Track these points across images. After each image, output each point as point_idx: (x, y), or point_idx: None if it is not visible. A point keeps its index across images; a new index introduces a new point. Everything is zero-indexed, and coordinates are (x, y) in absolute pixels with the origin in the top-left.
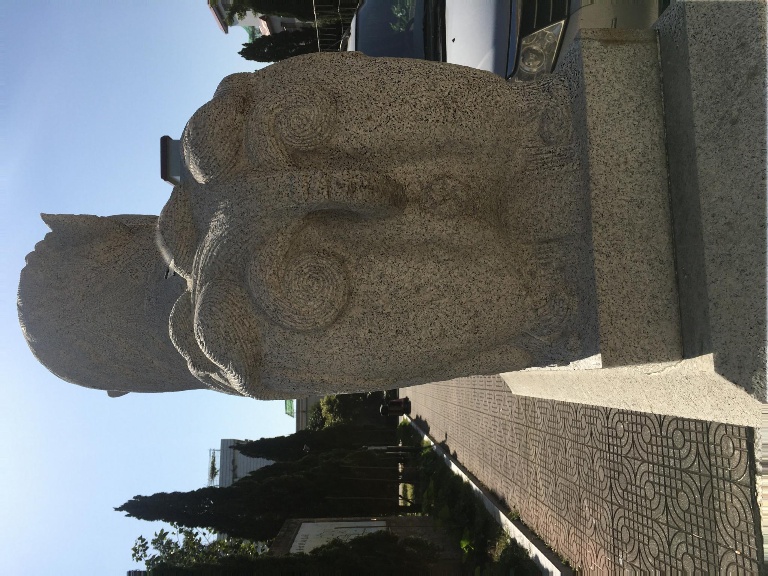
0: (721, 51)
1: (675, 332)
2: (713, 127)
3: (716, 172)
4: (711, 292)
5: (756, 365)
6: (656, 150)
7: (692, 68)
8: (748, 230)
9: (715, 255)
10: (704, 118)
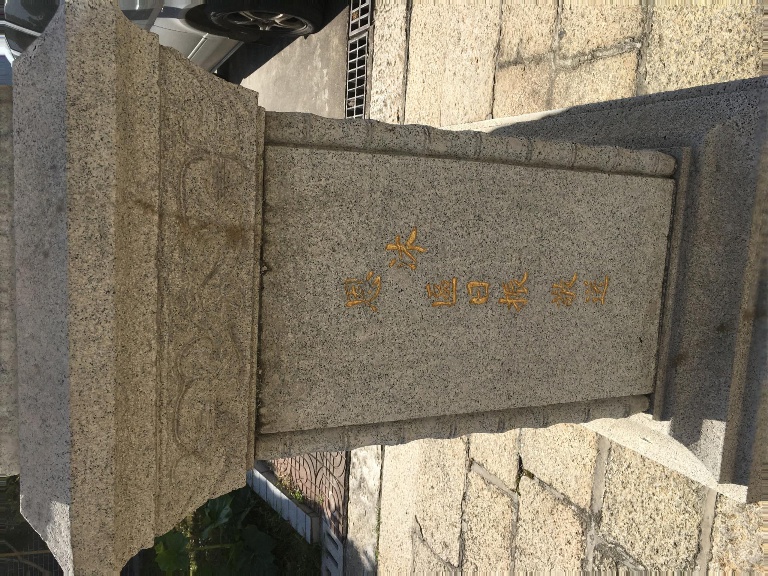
0: (39, 164)
1: (17, 445)
2: (30, 252)
3: (30, 305)
4: (21, 432)
5: (49, 516)
6: (6, 241)
7: (15, 172)
8: (49, 380)
9: (25, 395)
10: (23, 238)
